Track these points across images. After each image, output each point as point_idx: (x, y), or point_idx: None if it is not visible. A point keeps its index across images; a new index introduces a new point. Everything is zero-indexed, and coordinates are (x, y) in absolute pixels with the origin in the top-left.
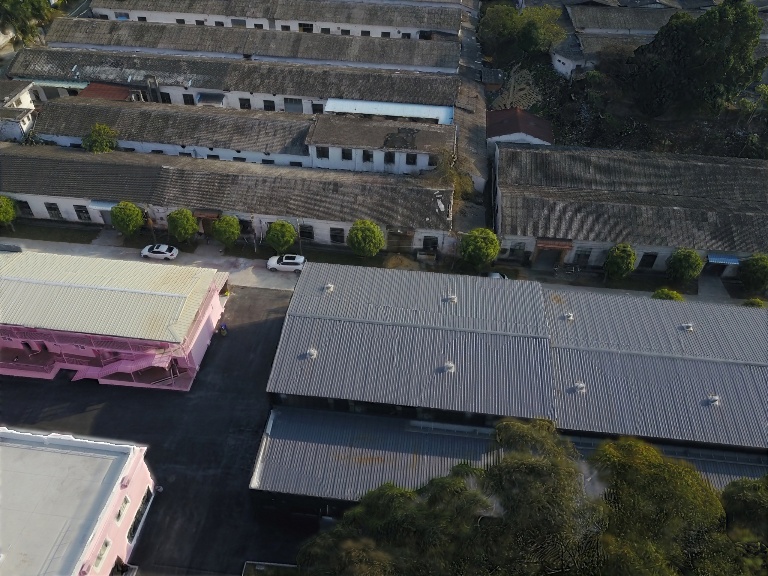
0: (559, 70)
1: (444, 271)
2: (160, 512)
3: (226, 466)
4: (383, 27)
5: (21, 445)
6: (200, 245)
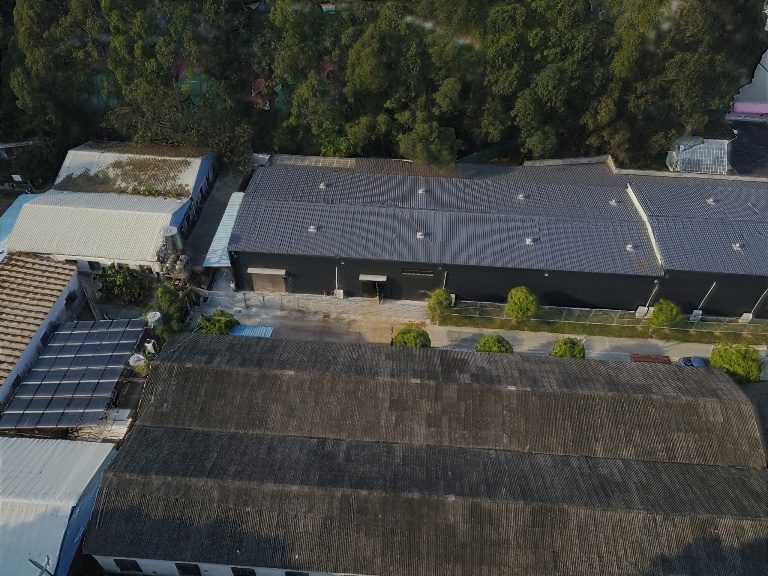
0: None
1: None
2: None
3: None
4: None
5: None
6: None
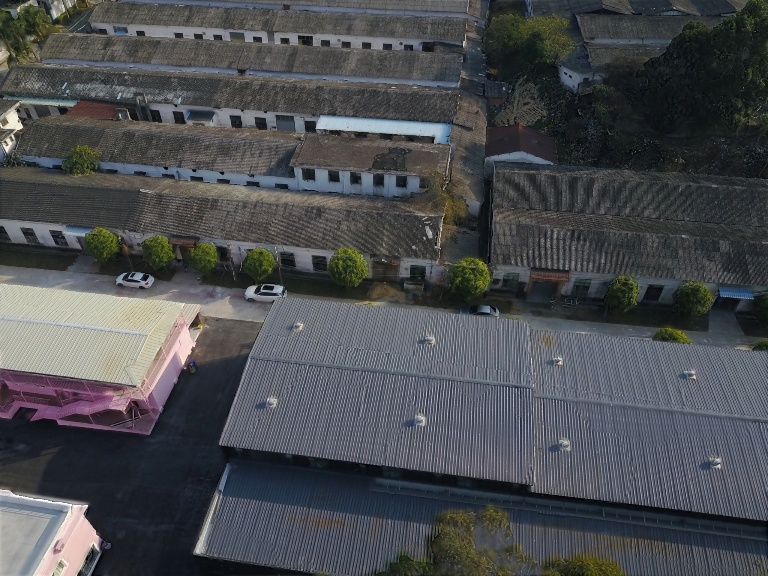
0: (566, 83)
1: (432, 302)
2: (106, 572)
3: (180, 521)
4: (384, 39)
5: None
6: (178, 272)
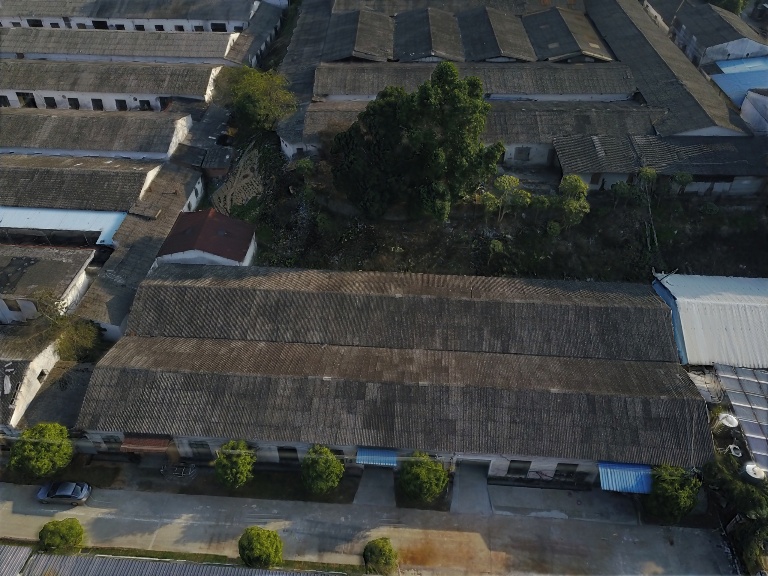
0: (285, 152)
1: (14, 476)
2: None
3: None
4: (115, 94)
5: None
6: None
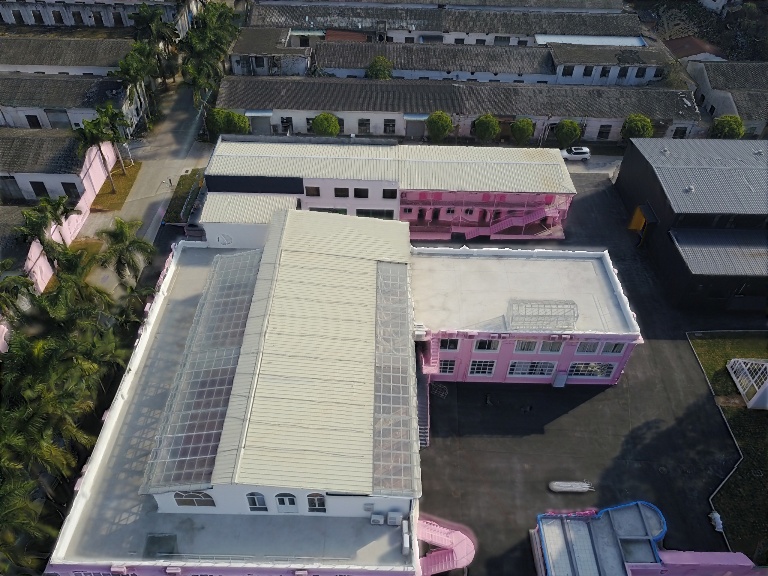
0: (709, 7)
1: None
2: None
3: (630, 280)
4: None
5: (517, 258)
6: None
